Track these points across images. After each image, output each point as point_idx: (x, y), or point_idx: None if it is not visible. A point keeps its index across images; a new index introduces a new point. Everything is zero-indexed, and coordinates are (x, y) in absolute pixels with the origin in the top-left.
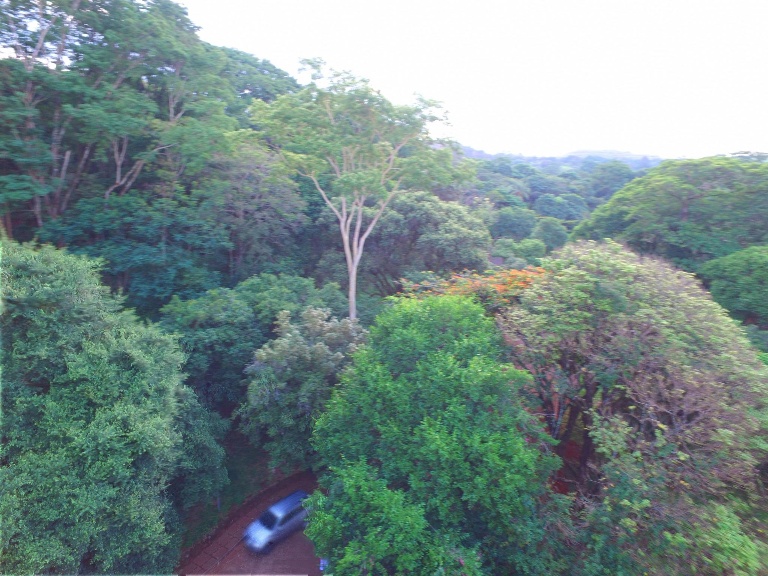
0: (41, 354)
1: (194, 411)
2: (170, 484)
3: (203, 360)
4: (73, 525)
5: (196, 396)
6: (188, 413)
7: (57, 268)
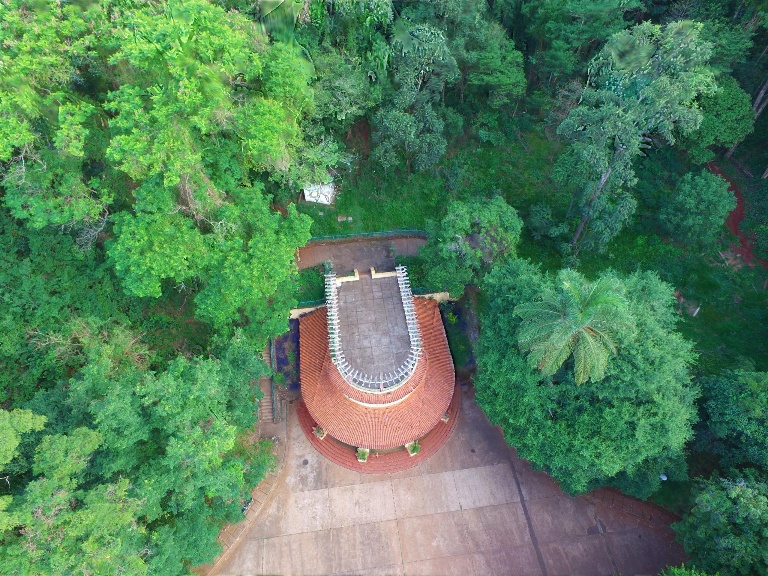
0: (600, 398)
1: (669, 457)
2: None
3: (726, 432)
4: None
5: (679, 453)
6: (662, 456)
7: (653, 361)
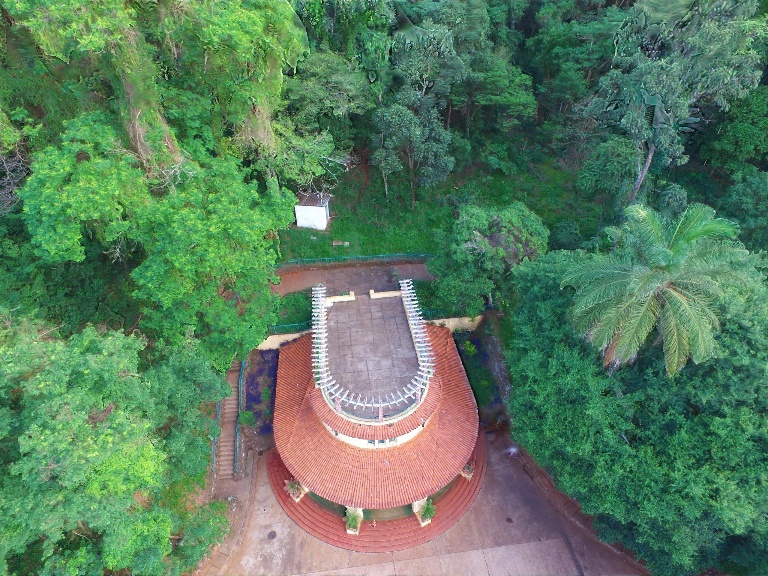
0: (703, 401)
1: None
2: (729, 536)
3: None
4: (638, 508)
5: None
6: None
7: None
